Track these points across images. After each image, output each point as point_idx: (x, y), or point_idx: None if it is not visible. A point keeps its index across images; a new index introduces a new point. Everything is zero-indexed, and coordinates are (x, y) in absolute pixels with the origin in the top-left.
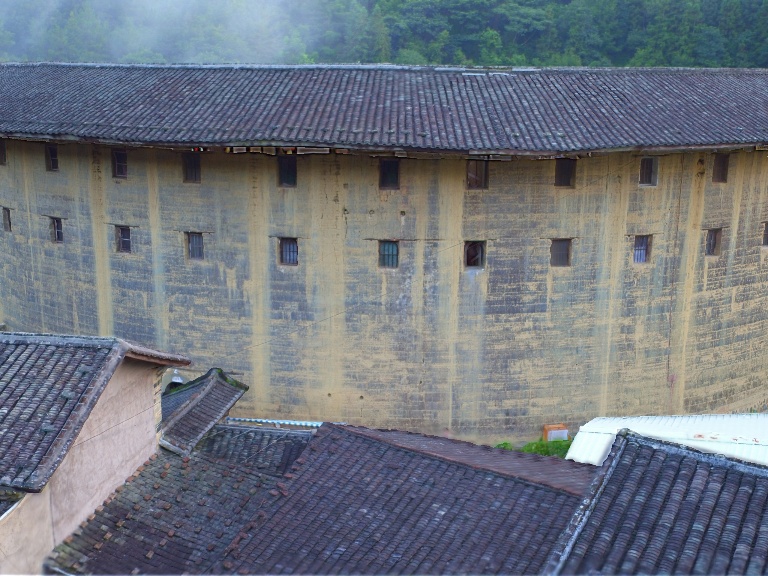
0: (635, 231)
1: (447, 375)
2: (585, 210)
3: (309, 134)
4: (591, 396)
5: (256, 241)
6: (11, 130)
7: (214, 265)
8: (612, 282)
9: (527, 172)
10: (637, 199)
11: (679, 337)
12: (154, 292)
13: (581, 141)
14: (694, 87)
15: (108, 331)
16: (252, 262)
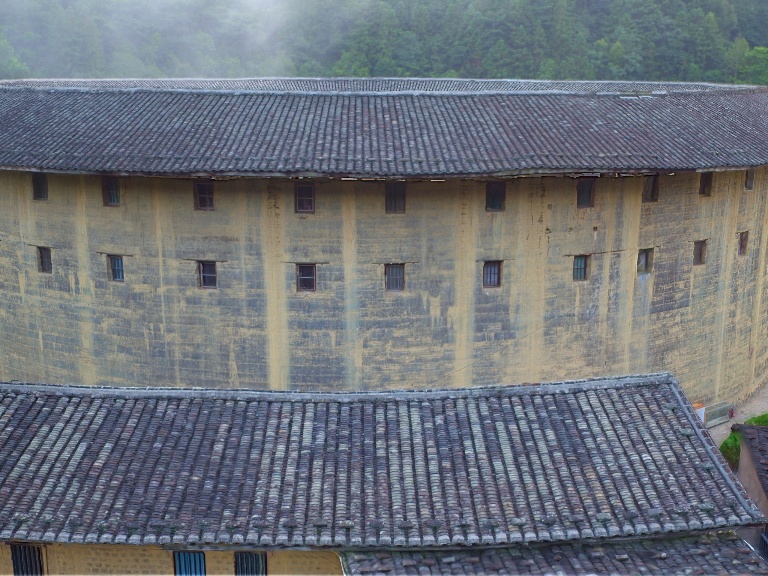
0: (741, 229)
1: (622, 373)
2: (715, 214)
3: (567, 160)
4: (712, 375)
5: (463, 267)
6: (222, 169)
7: (417, 295)
8: (727, 274)
9: (683, 184)
10: (743, 202)
11: (755, 316)
12: (345, 329)
13: (758, 156)
14: (762, 104)
15: (282, 377)
16: (458, 288)
